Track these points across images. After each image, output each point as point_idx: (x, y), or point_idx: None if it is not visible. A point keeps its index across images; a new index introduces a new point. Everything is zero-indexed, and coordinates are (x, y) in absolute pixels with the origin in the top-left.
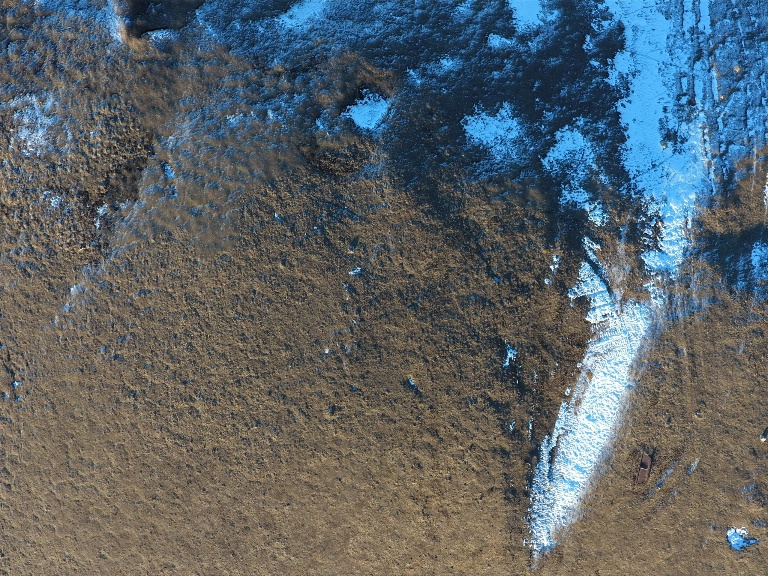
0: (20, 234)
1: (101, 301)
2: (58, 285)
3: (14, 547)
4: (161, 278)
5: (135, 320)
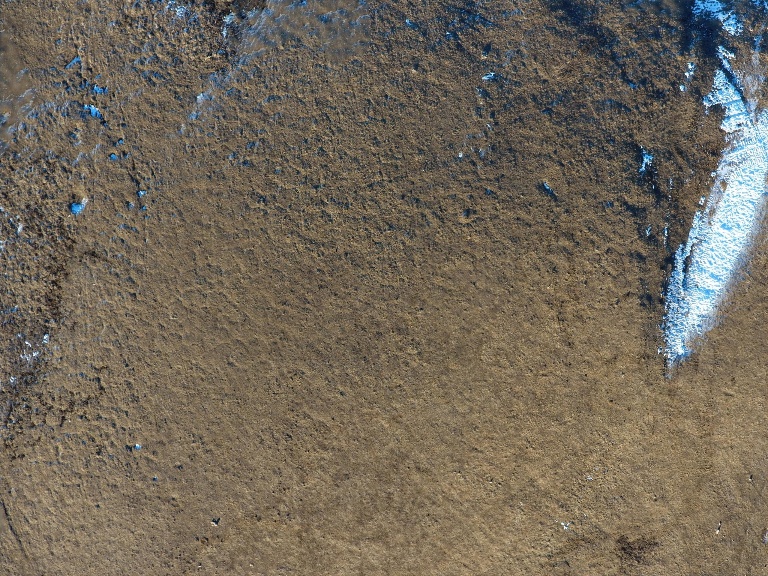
0: (144, 44)
1: (229, 108)
2: (184, 93)
3: (139, 357)
4: (291, 84)
5: (264, 126)
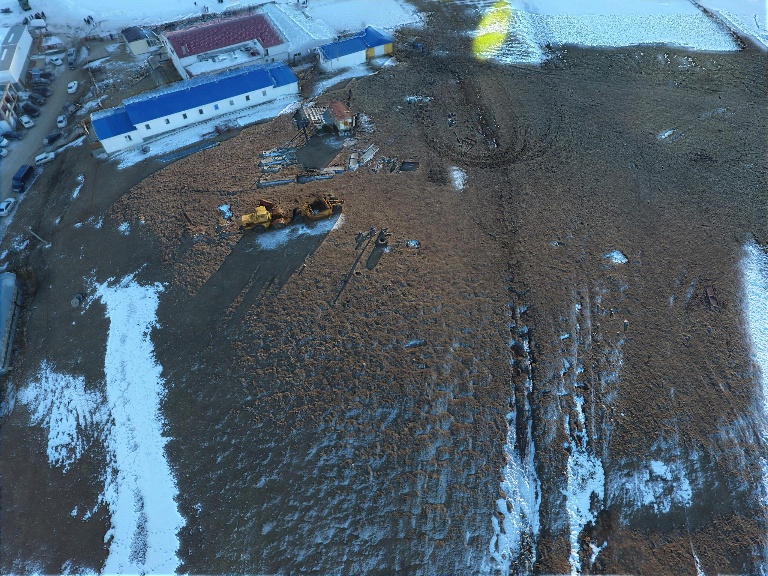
0: None
1: None
2: None
3: None
4: None
5: None
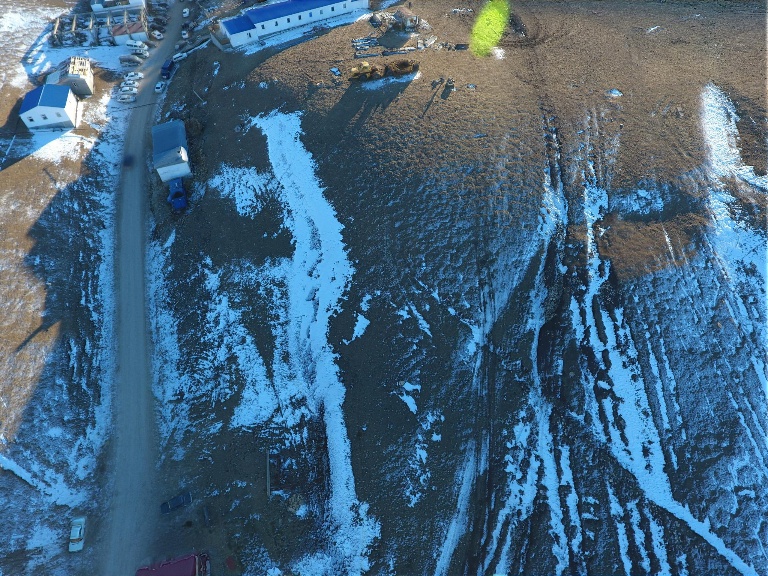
0: None
1: None
2: None
3: None
4: None
5: None
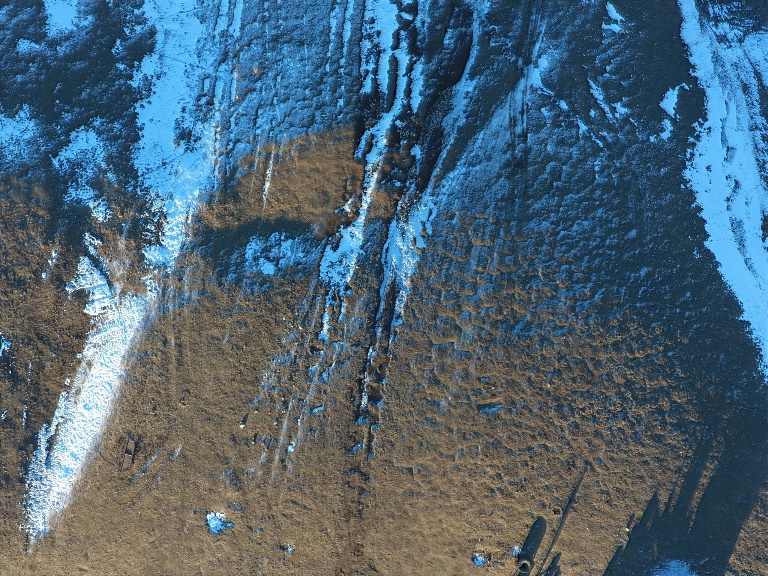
0: None
1: None
2: None
3: None
4: None
5: None
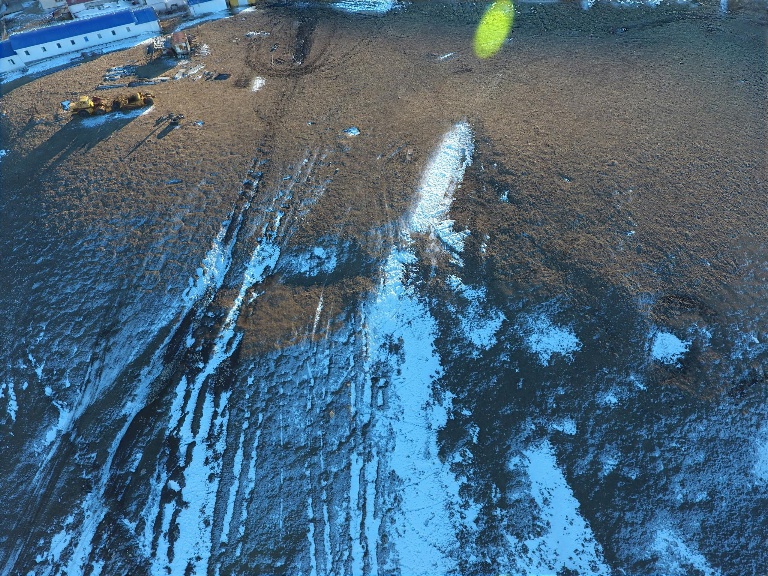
0: None
1: None
2: None
3: None
4: None
5: None
